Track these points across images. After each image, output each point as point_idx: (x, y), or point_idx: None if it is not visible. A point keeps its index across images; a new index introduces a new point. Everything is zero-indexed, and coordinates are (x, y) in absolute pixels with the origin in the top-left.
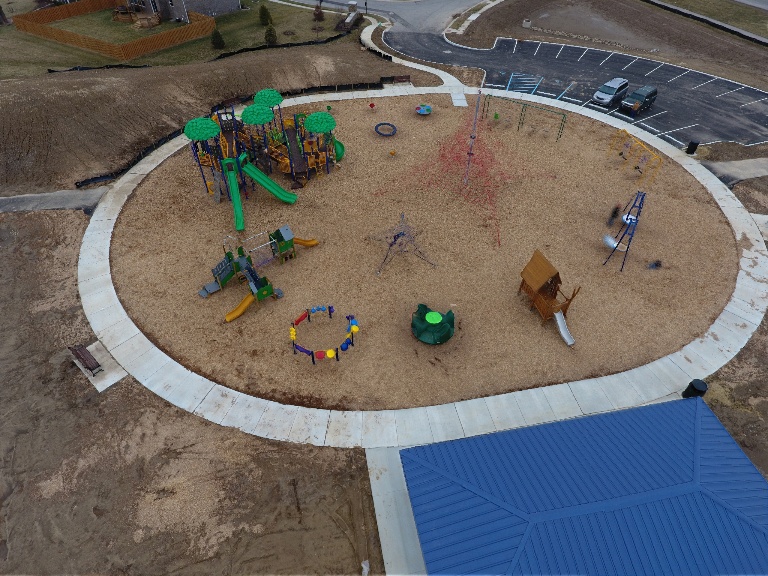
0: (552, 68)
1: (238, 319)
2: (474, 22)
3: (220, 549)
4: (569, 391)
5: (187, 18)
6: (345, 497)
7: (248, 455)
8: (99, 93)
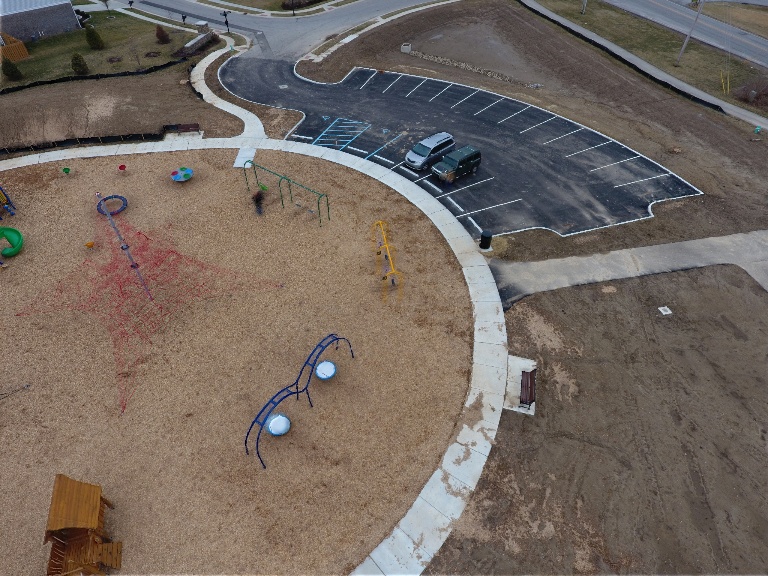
0: (391, 111)
1: None
2: (343, 46)
3: None
4: None
5: (2, 40)
6: None
7: None
8: None
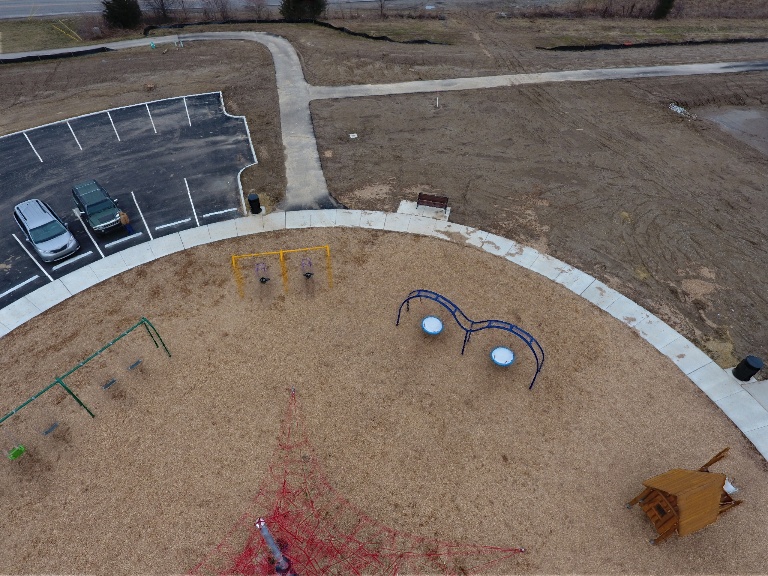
0: None
1: None
2: None
3: None
4: None
5: None
6: None
7: None
8: None
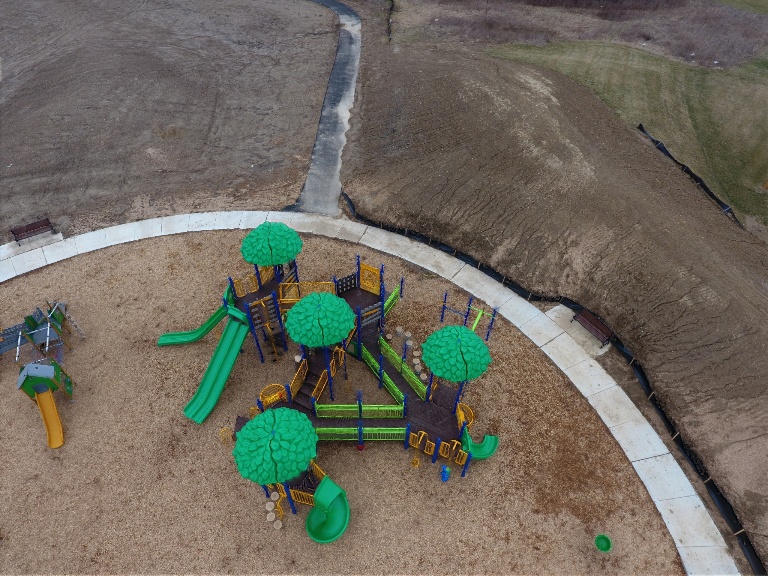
0: None
1: None
2: None
3: None
4: None
5: None
6: None
7: None
8: (539, 164)
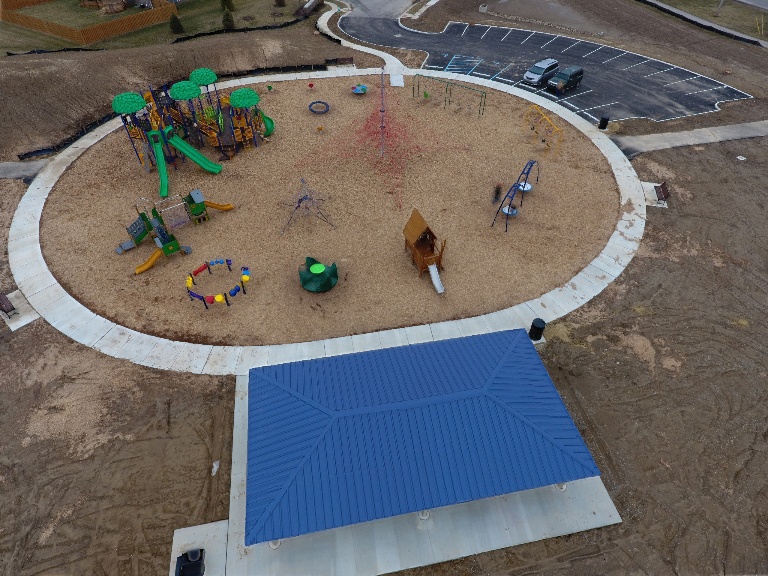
0: (494, 50)
1: (147, 272)
2: (431, 7)
3: (95, 452)
4: (429, 331)
5: (151, 4)
6: (211, 413)
7: (133, 381)
8: (49, 74)
